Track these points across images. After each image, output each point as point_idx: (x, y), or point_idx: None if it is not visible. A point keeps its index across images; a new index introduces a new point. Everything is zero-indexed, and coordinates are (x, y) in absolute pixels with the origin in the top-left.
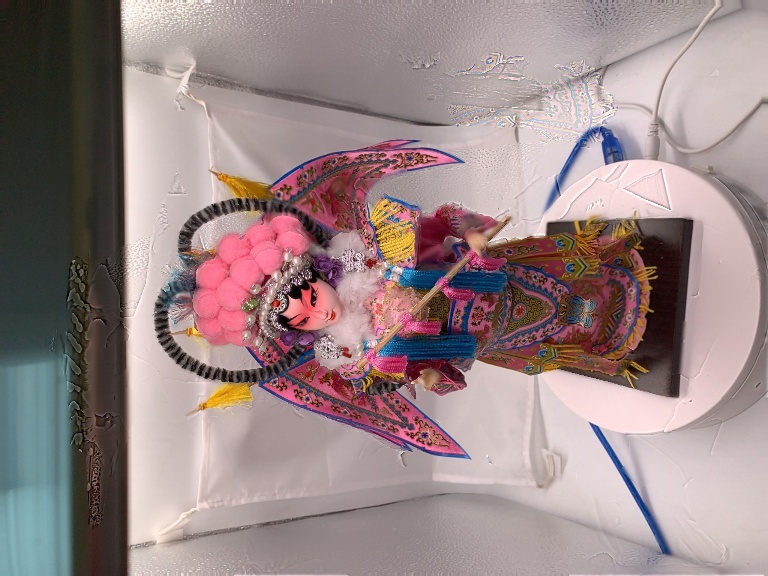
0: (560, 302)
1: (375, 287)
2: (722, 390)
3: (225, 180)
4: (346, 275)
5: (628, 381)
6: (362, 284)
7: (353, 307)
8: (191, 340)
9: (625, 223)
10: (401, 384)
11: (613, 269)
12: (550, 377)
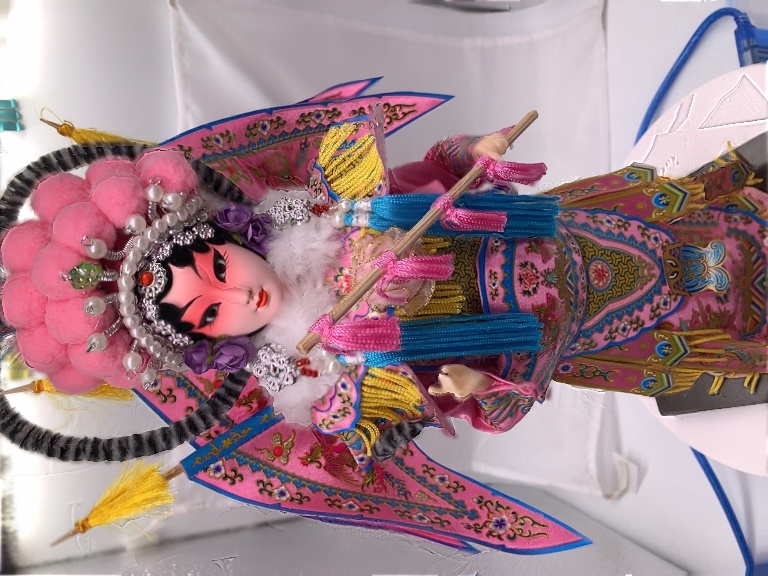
0: (663, 257)
1: (333, 244)
2: None
3: (70, 133)
4: (280, 233)
5: None
6: (309, 242)
7: (305, 288)
8: (42, 400)
9: (719, 162)
10: (425, 419)
11: (728, 214)
12: (687, 432)
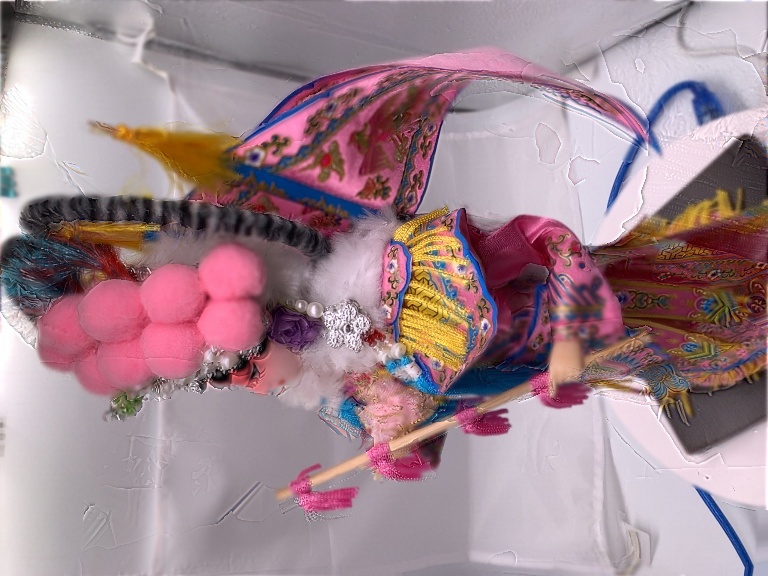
0: (640, 368)
1: (367, 369)
2: (749, 505)
3: (131, 137)
4: (325, 345)
5: (658, 409)
6: None
7: None
8: None
9: None
10: None
11: None
12: None
